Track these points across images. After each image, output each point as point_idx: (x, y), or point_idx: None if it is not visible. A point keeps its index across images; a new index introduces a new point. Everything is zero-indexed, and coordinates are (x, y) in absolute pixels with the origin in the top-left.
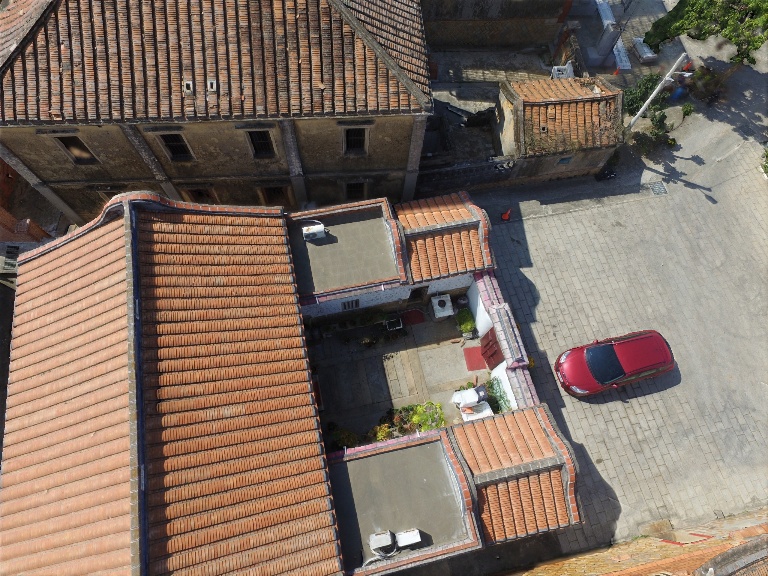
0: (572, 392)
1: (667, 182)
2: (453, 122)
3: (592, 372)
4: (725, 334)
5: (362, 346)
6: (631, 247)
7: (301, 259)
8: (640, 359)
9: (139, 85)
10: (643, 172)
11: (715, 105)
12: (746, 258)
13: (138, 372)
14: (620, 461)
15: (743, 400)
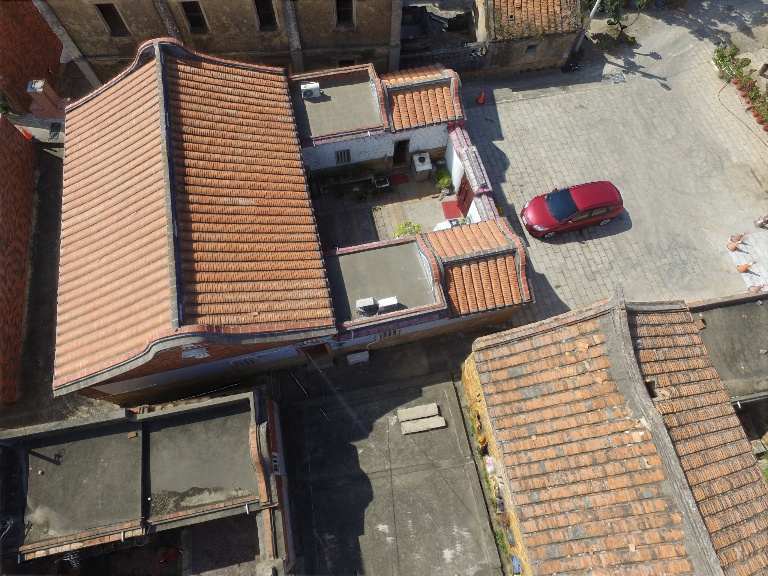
0: (535, 232)
1: (626, 73)
2: (436, 28)
3: (551, 212)
4: (673, 192)
5: (354, 200)
6: (592, 124)
7: (300, 113)
8: (592, 199)
9: None
10: (605, 65)
11: (674, 12)
12: (695, 133)
13: (170, 160)
14: (576, 287)
15: (686, 242)
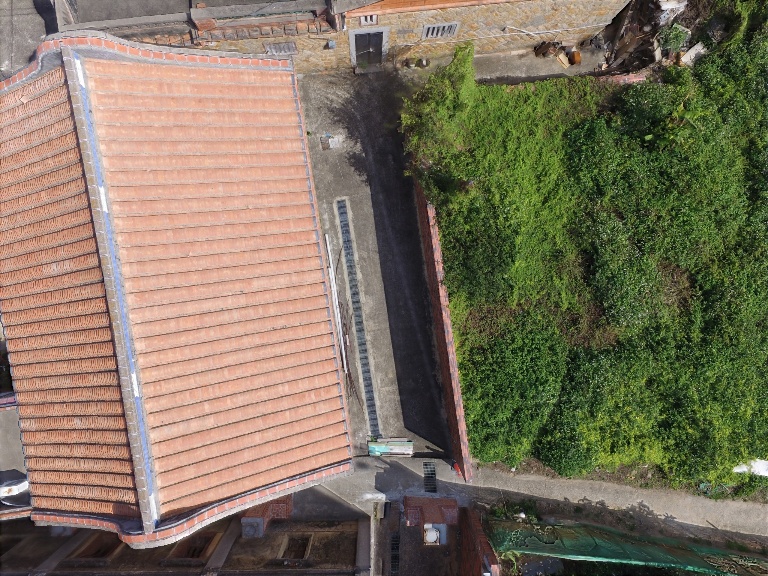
0: None
1: None
2: None
3: None
4: None
5: None
6: None
7: None
8: None
9: None
10: None
11: None
12: None
13: None
14: None
15: None
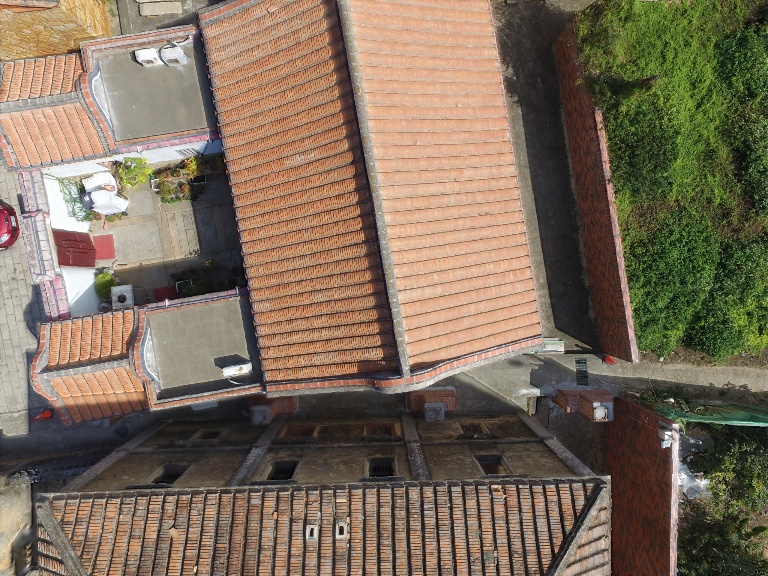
0: (4, 205)
1: None
2: None
3: None
4: None
5: None
6: None
7: (255, 339)
8: None
9: (401, 532)
10: None
11: None
12: None
13: None
14: None
15: None
